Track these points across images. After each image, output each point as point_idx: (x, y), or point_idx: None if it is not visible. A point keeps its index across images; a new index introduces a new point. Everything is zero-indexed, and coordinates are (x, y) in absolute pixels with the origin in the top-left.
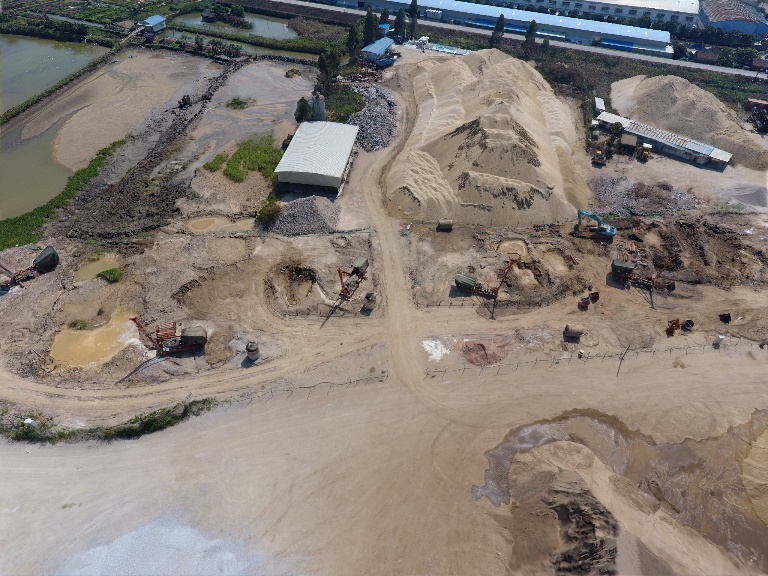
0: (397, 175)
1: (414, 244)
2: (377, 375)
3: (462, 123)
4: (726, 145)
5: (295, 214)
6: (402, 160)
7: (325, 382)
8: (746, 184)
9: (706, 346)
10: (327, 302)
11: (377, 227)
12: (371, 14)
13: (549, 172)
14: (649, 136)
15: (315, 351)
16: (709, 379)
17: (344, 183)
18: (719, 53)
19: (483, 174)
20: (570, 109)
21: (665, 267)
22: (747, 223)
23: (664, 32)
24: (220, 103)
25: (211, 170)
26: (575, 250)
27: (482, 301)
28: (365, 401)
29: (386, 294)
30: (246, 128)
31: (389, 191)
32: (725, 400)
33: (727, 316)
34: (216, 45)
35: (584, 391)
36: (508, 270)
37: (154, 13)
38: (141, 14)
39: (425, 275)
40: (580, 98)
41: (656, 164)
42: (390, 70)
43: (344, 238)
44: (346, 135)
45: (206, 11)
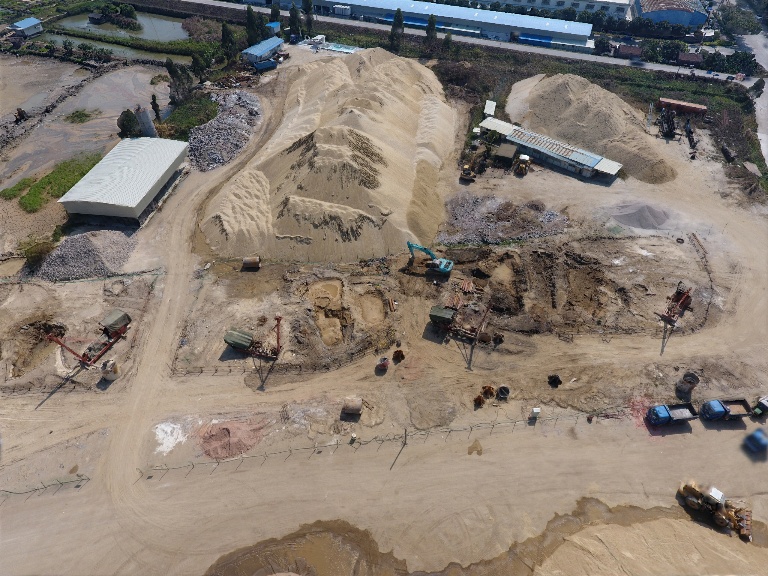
0: (217, 200)
1: (205, 288)
2: (76, 477)
3: (301, 137)
4: (619, 154)
5: (64, 255)
6: (231, 181)
7: (2, 490)
8: (632, 201)
9: (518, 422)
10: (59, 372)
11: (170, 267)
12: (251, 11)
13: (390, 194)
14: (531, 145)
15: (12, 443)
16: (508, 470)
17: (155, 211)
18: (646, 46)
19: (305, 199)
20: (457, 114)
21: (503, 311)
22: (618, 251)
23: (586, 25)
24: (60, 116)
25: (6, 198)
26: (399, 291)
27: (258, 365)
28: (43, 518)
29: (141, 358)
30: (75, 145)
31: (203, 220)
32: (519, 502)
33: (555, 379)
34: (85, 49)
35: (340, 493)
36: (277, 329)
37: (38, 15)
38: (23, 16)
39: (200, 331)
40: (472, 101)
41: (534, 178)
42: (271, 73)
43: (122, 283)
44: (167, 153)
45: (94, 12)
